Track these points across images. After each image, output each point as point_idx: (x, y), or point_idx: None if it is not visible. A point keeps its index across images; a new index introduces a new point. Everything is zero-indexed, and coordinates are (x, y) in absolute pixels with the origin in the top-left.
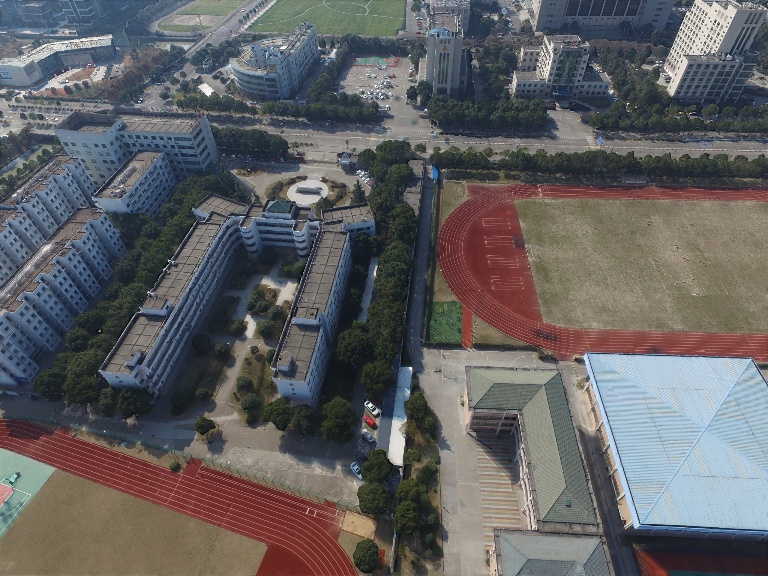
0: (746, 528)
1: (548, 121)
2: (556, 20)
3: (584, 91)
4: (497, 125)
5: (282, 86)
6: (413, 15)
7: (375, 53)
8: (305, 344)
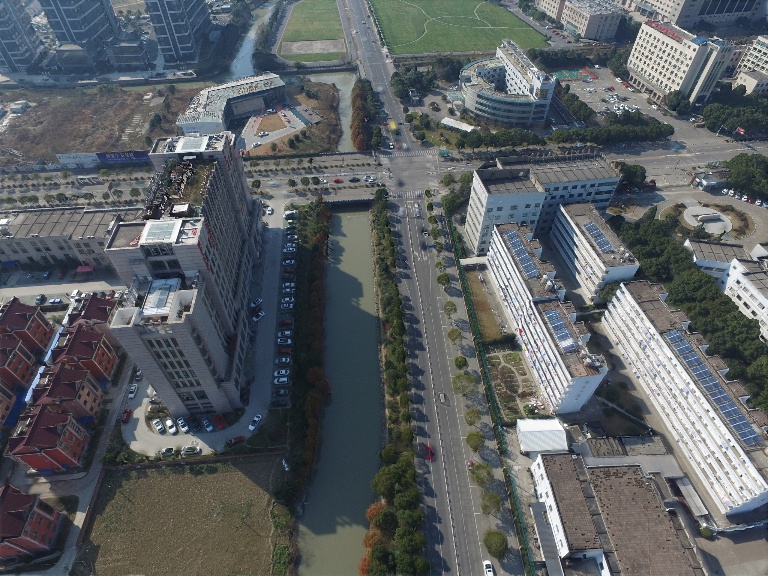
0: None
1: None
2: (691, 20)
3: None
4: None
5: None
6: (536, 24)
7: (560, 66)
8: None
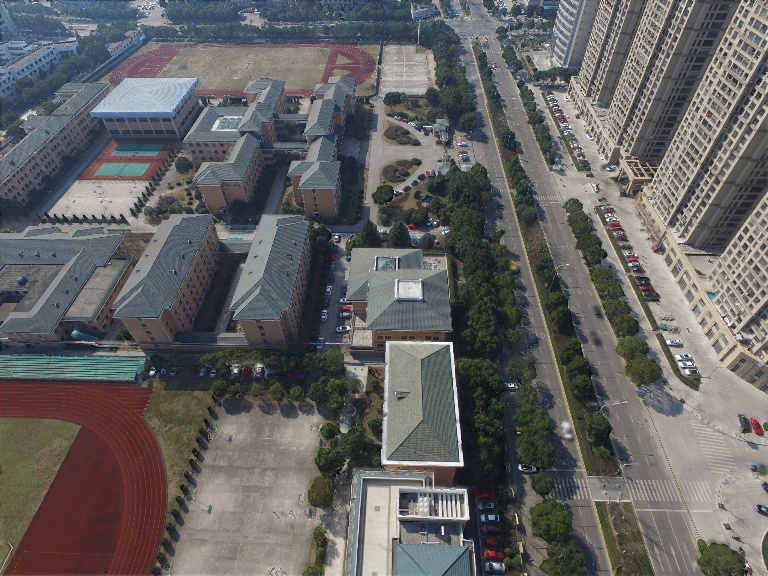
0: None
1: (242, 18)
2: None
3: (274, 1)
4: (202, 17)
5: (81, 0)
6: None
7: None
8: None
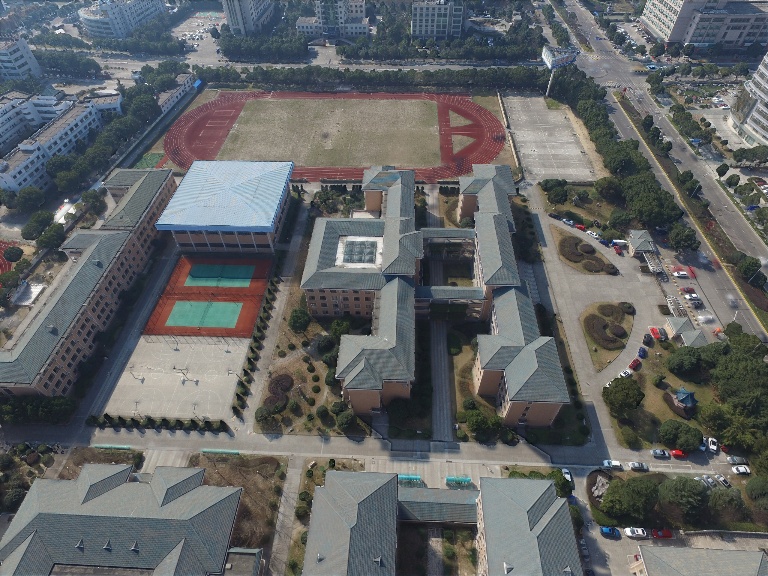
0: (212, 225)
1: (312, 53)
2: None
3: (349, 32)
4: (266, 54)
5: (116, 29)
6: None
7: (214, 9)
8: (21, 159)
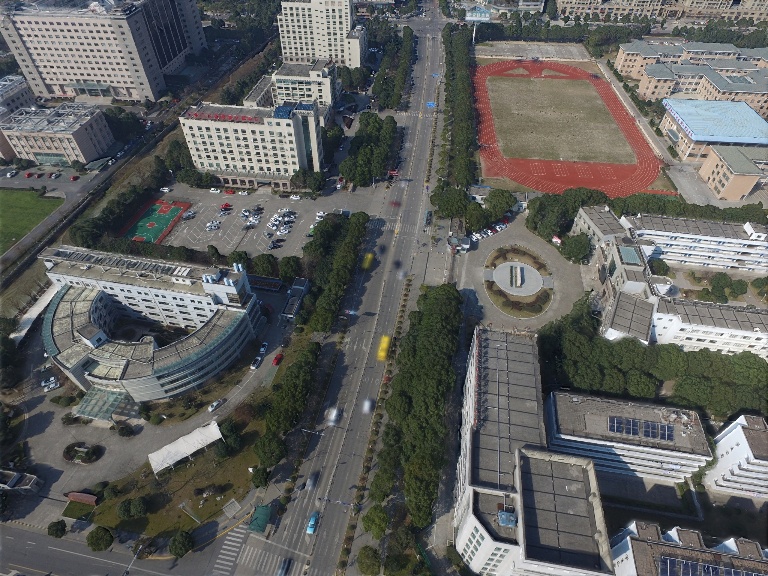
0: None
1: None
2: (160, 80)
3: None
4: None
5: None
6: None
7: (127, 220)
8: None
